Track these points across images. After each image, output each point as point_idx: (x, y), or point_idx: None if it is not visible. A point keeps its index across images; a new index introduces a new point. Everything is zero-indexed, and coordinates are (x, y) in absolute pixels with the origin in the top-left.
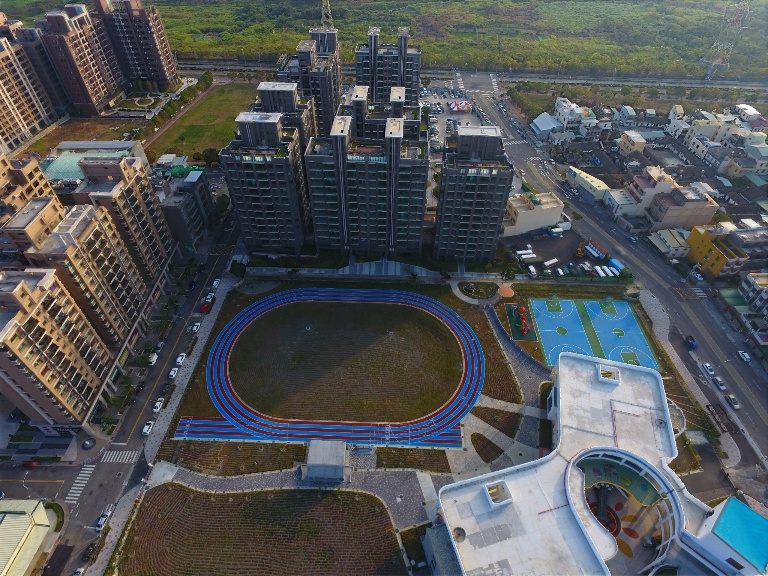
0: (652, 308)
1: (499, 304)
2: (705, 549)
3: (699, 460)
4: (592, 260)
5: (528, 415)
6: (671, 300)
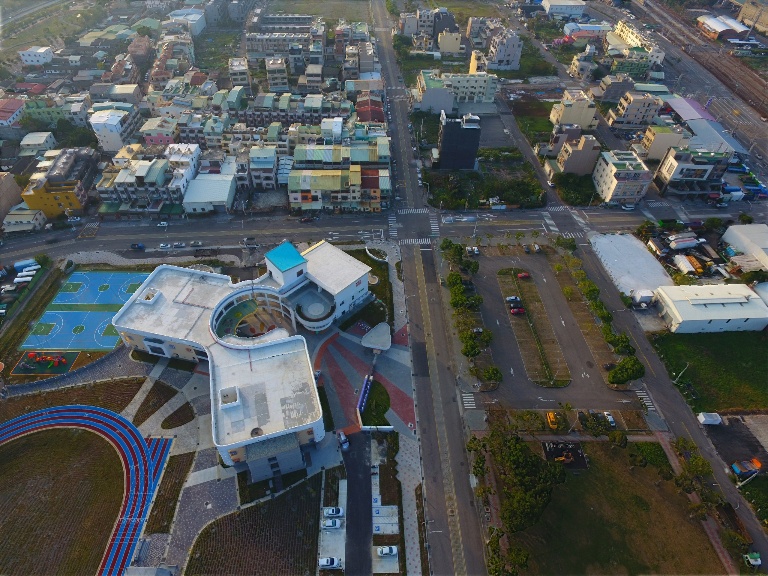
0: (90, 258)
1: (7, 380)
2: (290, 285)
3: (232, 276)
4: (2, 283)
5: (159, 375)
6: (89, 244)
